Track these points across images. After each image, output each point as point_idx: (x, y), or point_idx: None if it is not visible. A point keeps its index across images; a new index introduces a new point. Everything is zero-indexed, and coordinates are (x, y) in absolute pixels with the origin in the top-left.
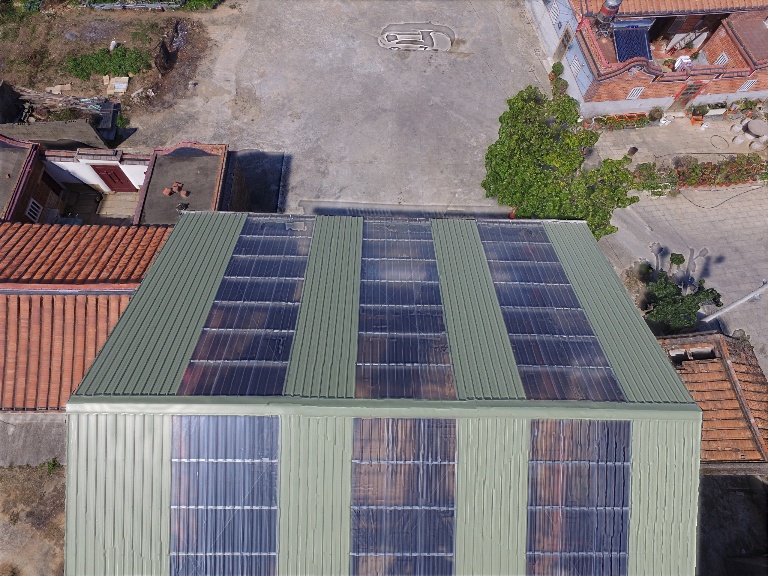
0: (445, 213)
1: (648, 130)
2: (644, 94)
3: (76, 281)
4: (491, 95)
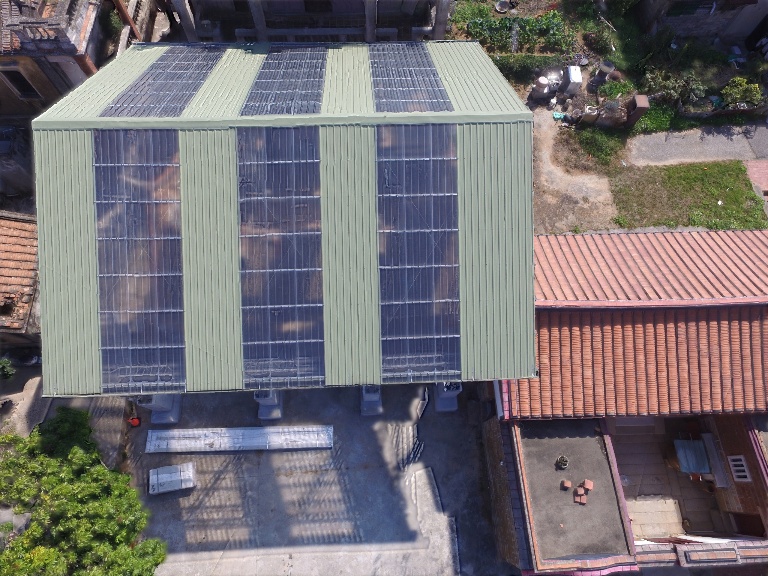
0: (227, 544)
1: None
2: None
3: (620, 322)
4: None
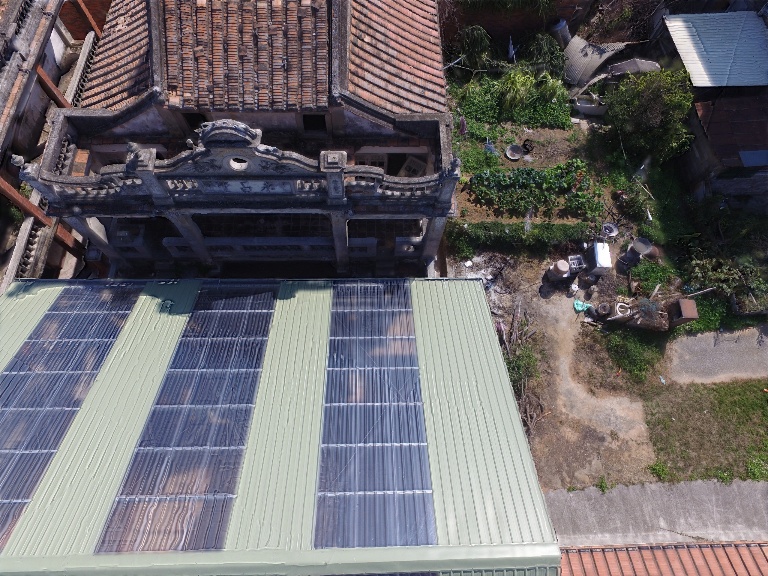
0: None
1: None
2: None
3: None
4: None
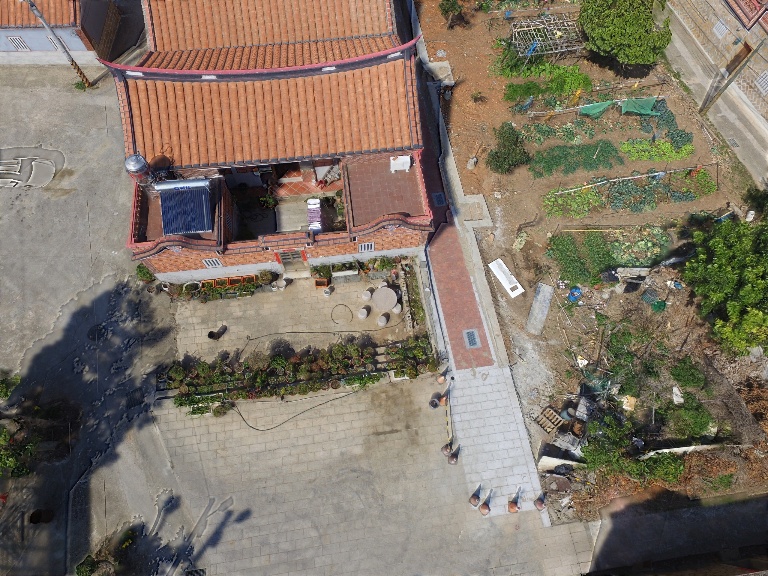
0: None
1: (255, 298)
2: (228, 262)
3: None
4: (70, 251)
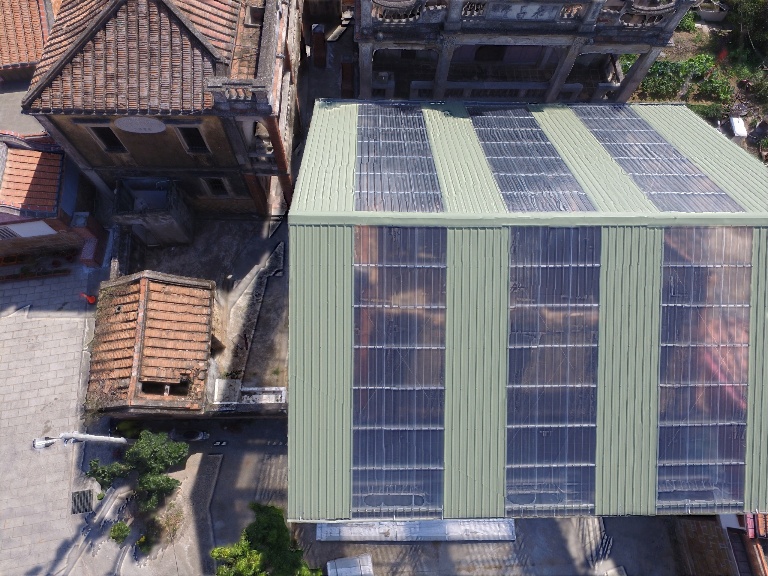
0: None
1: None
2: None
3: None
4: None
